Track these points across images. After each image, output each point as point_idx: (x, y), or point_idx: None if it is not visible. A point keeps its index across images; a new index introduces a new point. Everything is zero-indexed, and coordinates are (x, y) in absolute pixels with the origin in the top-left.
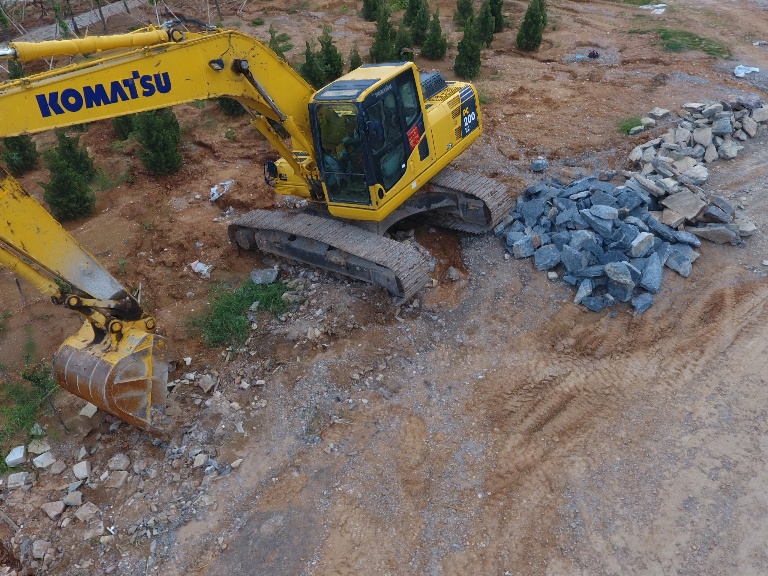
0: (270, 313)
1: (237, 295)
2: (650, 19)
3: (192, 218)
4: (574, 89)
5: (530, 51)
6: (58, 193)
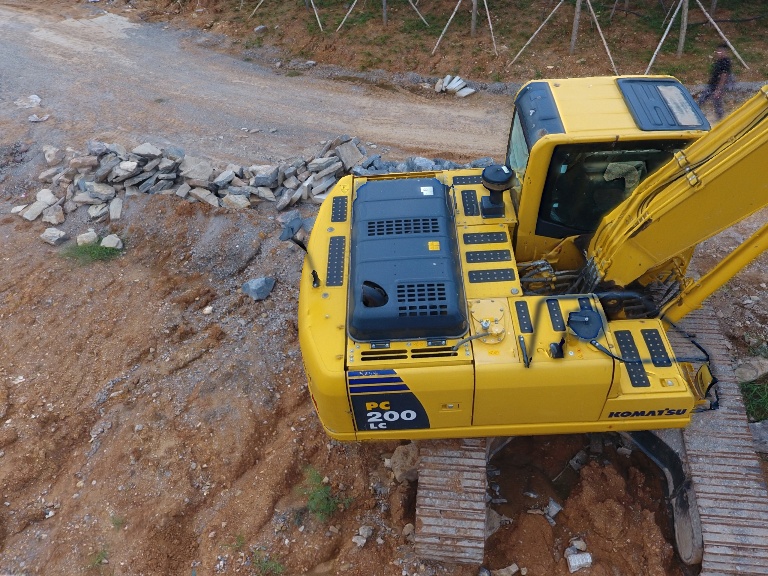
0: None
1: None
2: None
3: None
4: None
5: None
6: None
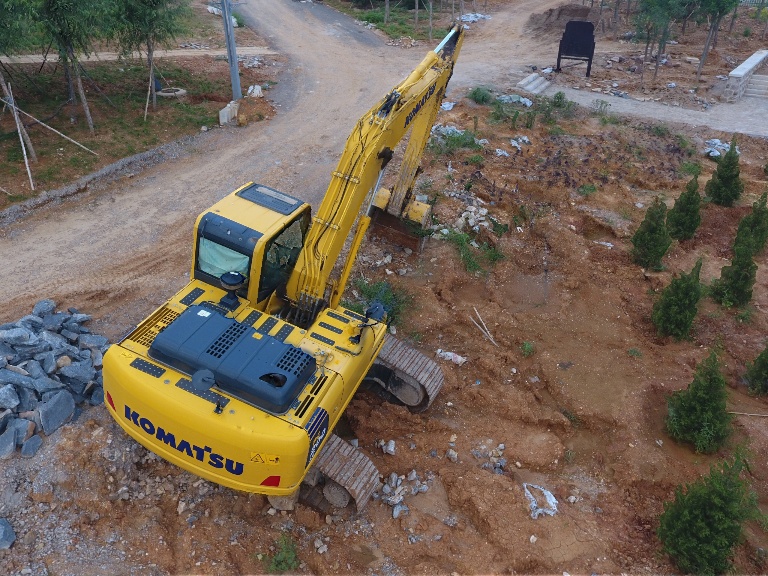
0: None
1: None
2: None
3: (533, 441)
4: None
5: None
6: None
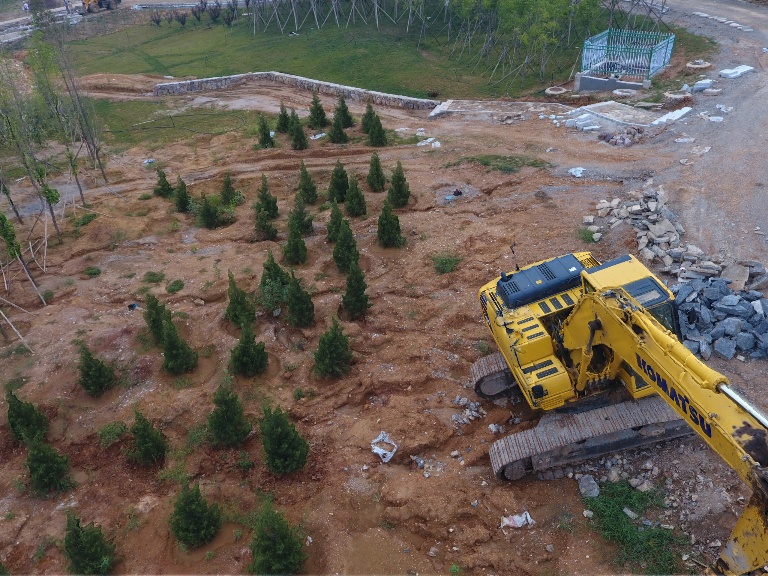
0: (653, 509)
1: (609, 515)
2: (442, 152)
3: (407, 488)
4: (501, 224)
5: (404, 206)
6: (280, 555)
